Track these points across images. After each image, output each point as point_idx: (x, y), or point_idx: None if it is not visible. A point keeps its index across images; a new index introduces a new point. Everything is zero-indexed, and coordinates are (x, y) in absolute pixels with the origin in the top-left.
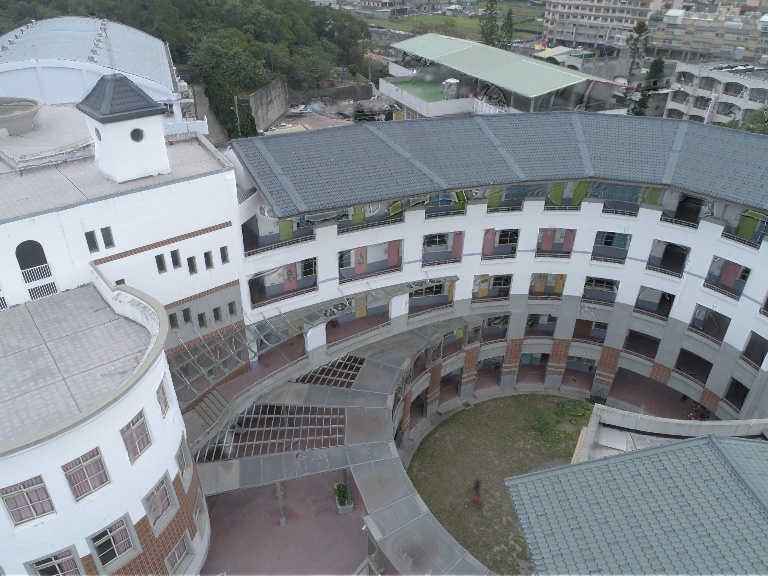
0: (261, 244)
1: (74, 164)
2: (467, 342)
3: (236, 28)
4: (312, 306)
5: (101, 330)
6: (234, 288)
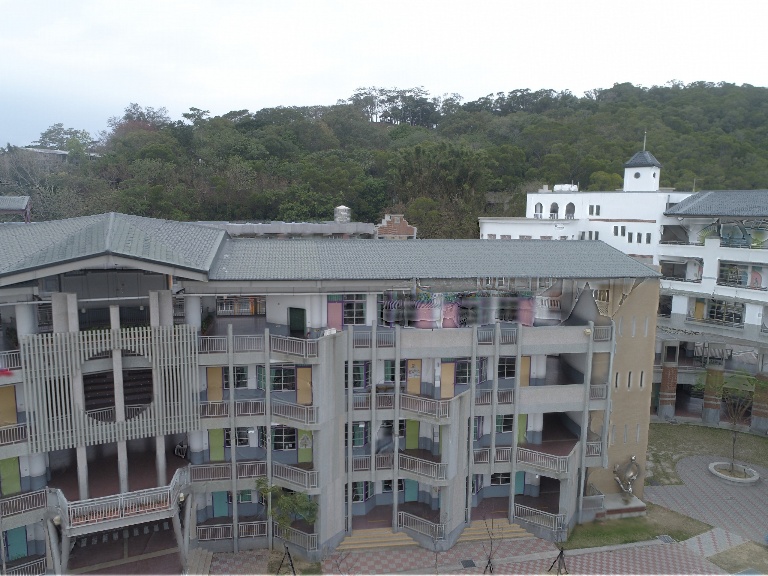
0: (673, 240)
1: None
2: None
3: None
4: None
5: None
6: (649, 260)
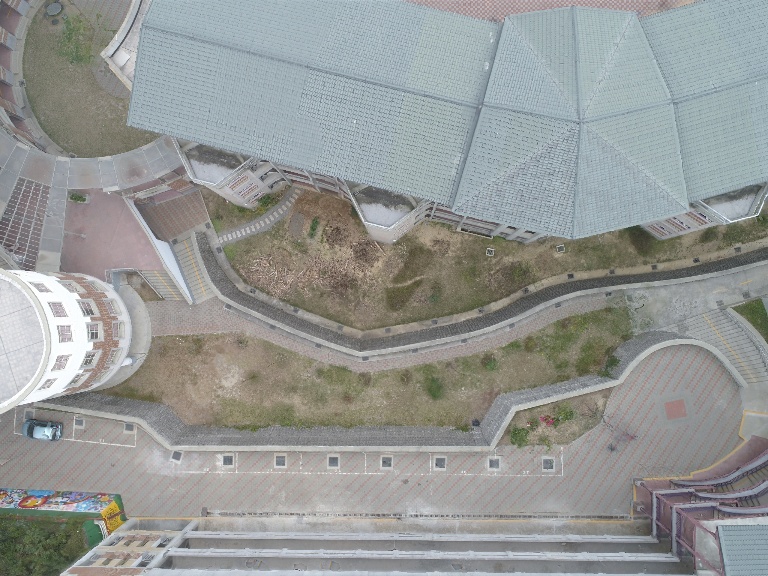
0: None
1: None
2: None
3: None
4: None
5: None
6: None
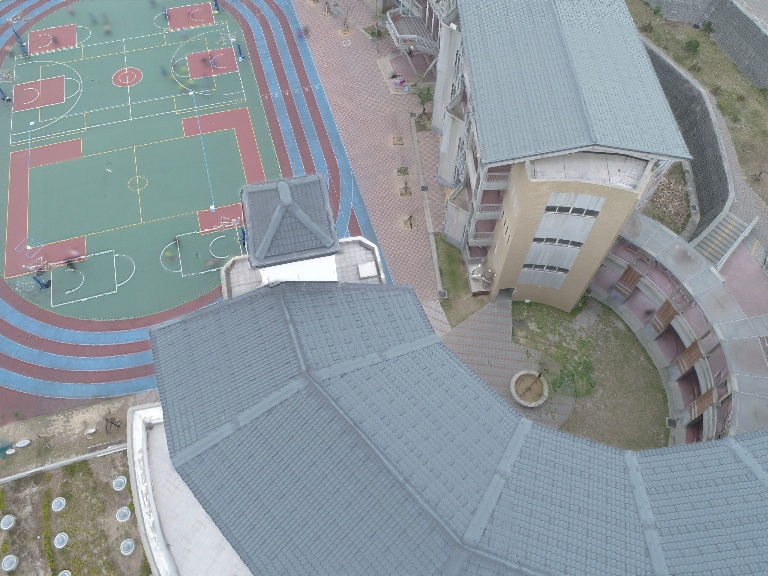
0: None
1: None
2: None
3: None
4: None
5: None
6: None
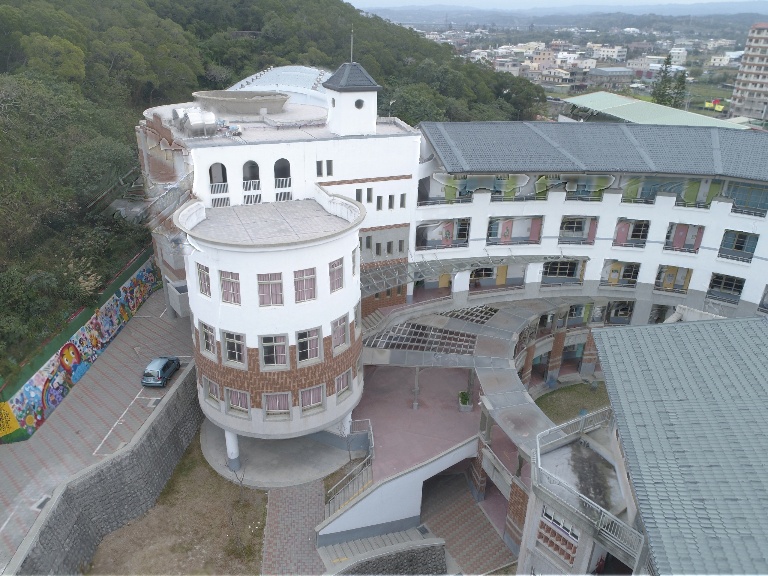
0: (430, 199)
1: (311, 127)
2: (592, 320)
3: (425, 83)
4: (462, 259)
5: (319, 218)
6: (405, 229)
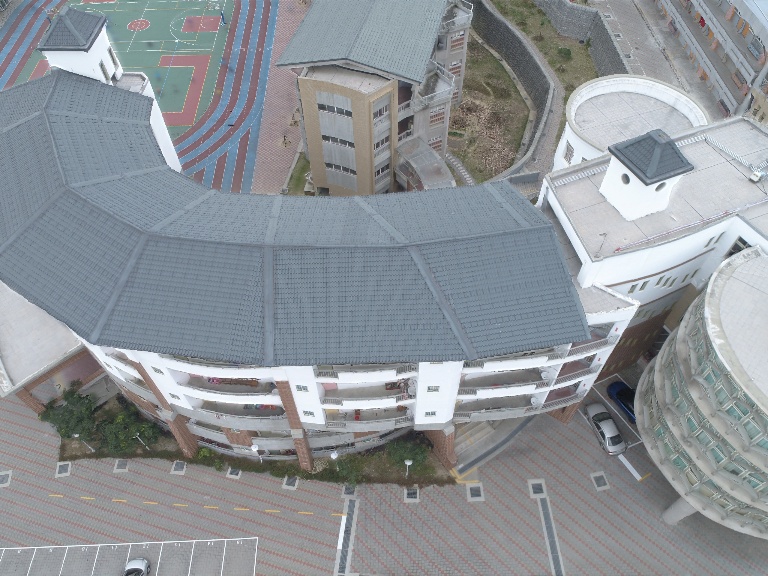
0: None
1: None
2: None
3: None
4: None
5: None
6: None
